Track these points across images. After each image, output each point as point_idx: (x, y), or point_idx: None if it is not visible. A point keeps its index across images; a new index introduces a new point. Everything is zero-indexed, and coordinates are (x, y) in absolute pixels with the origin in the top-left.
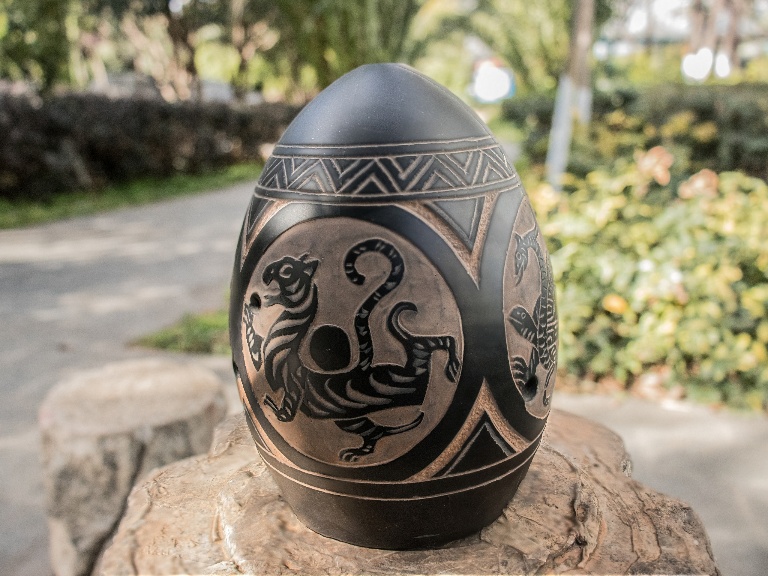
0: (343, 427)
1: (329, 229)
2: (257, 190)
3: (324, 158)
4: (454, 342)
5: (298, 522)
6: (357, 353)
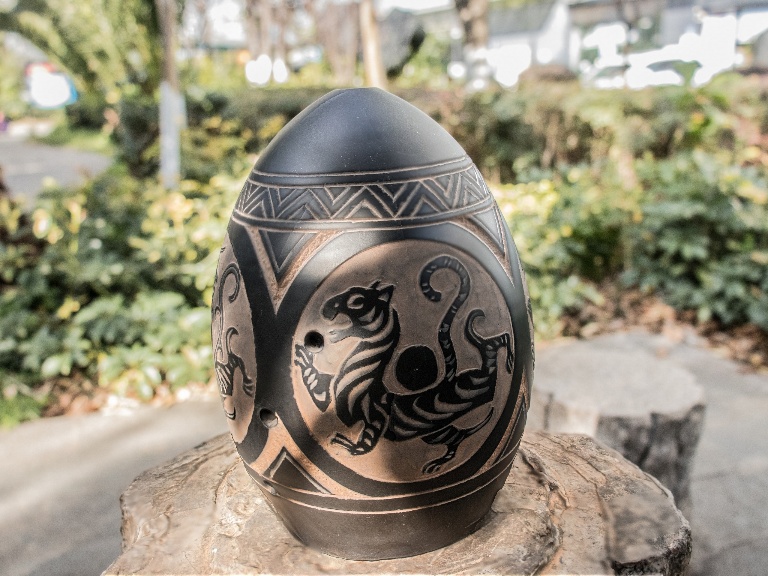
0: (430, 441)
1: (397, 253)
2: (271, 225)
3: (369, 184)
4: (509, 338)
5: (331, 559)
6: (443, 366)
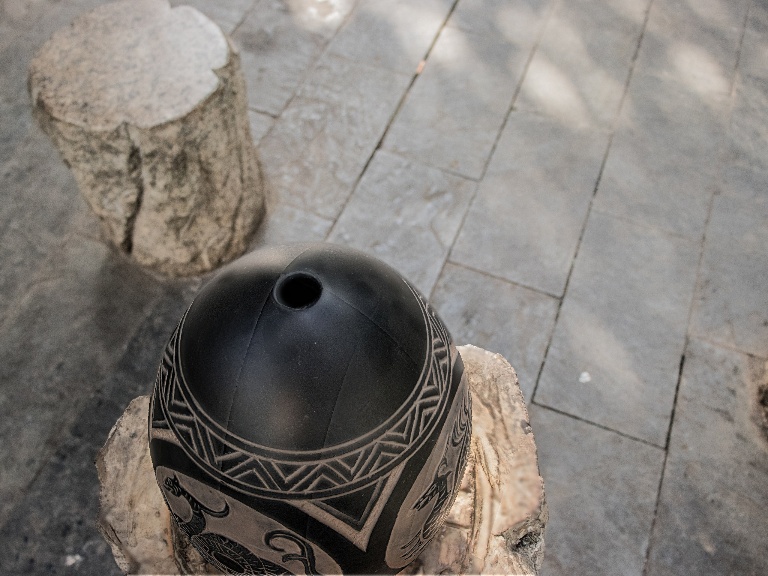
0: None
1: None
2: None
3: None
4: None
5: None
6: None
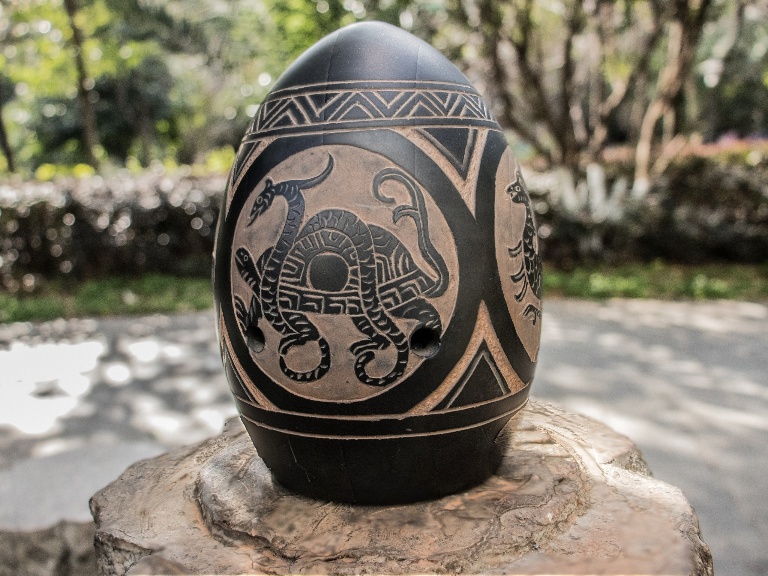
0: None
1: None
2: None
3: None
4: None
5: None
6: None
